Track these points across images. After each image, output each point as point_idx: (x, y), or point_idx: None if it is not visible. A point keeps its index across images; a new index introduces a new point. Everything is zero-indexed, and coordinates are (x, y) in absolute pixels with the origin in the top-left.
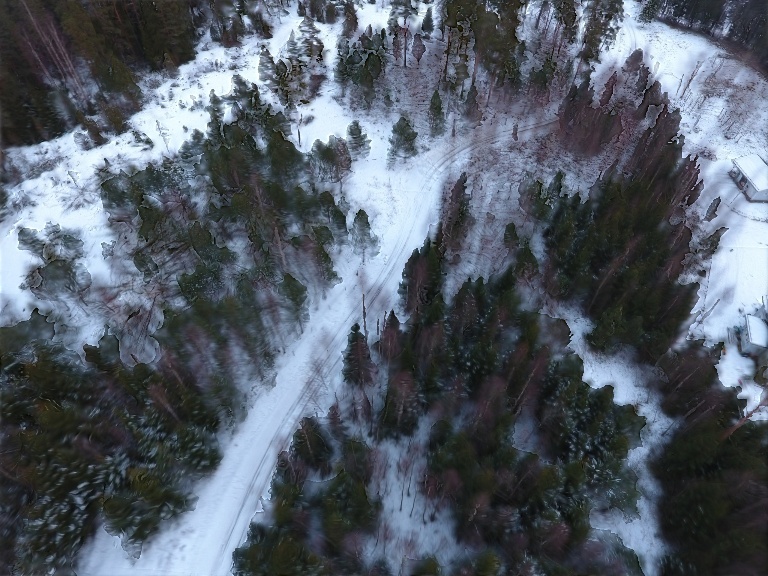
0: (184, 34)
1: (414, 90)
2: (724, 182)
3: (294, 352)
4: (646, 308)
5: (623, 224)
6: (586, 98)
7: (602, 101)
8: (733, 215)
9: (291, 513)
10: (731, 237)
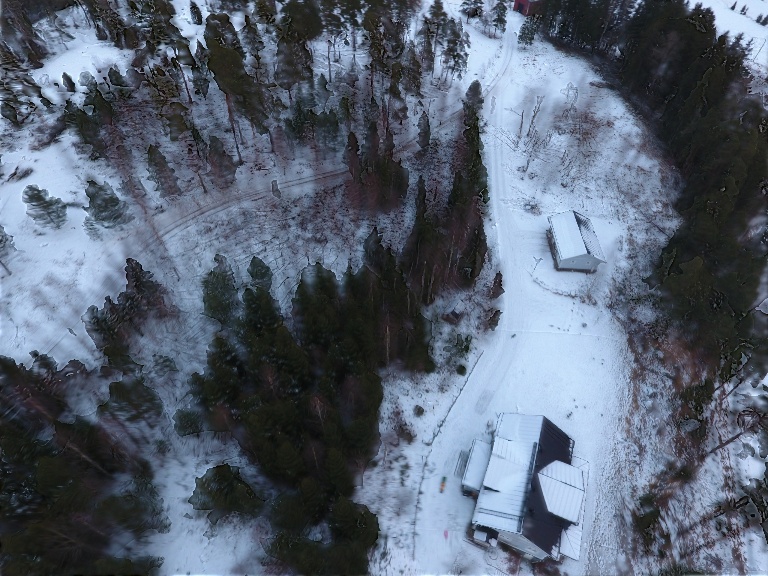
0: None
1: (185, 133)
2: (537, 243)
3: None
4: (278, 461)
5: (314, 328)
6: (374, 145)
7: (420, 143)
8: (534, 287)
9: None
10: (520, 317)
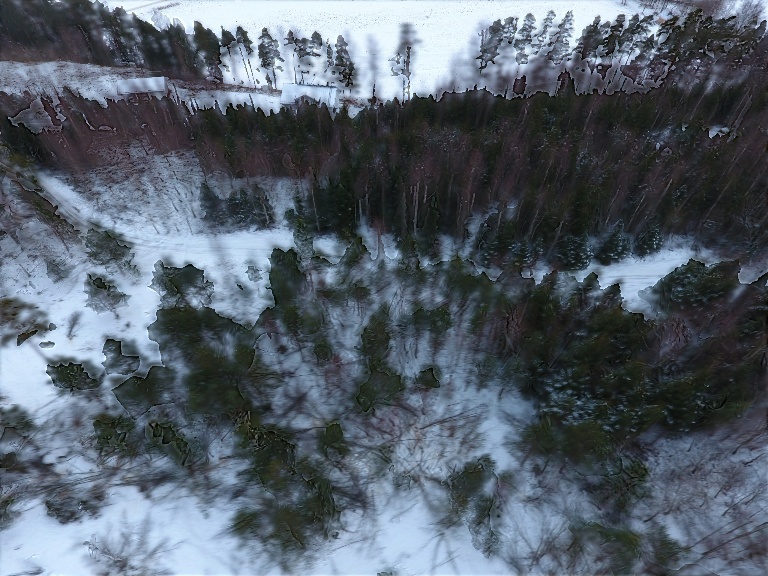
0: None
1: None
2: None
3: None
4: (331, 121)
5: (251, 120)
6: None
7: None
8: None
9: None
10: None
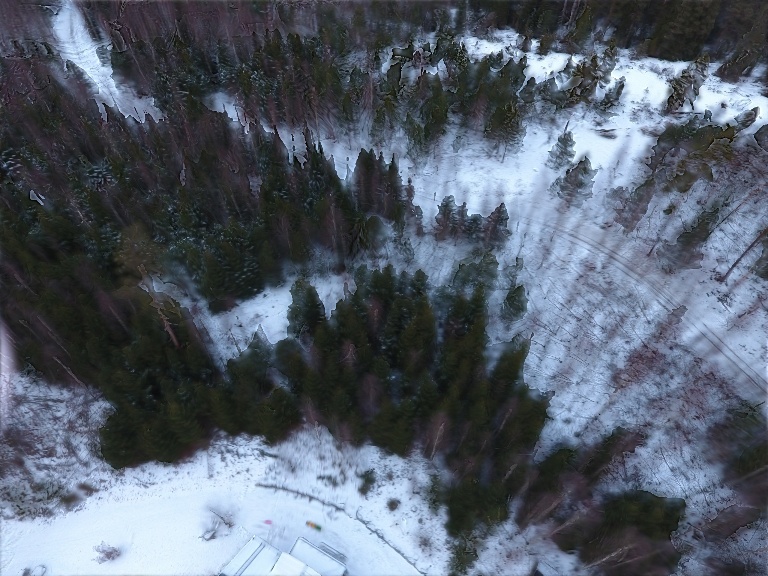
0: (692, 40)
1: (741, 219)
2: None
3: (334, 146)
4: None
5: (446, 353)
6: None
7: None
8: None
9: (214, 114)
10: None
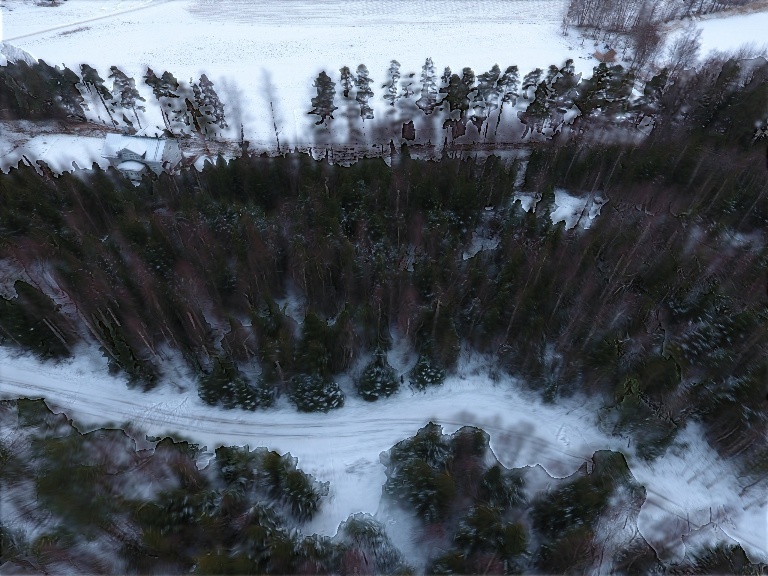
0: None
1: None
2: None
3: None
4: (111, 190)
5: None
6: None
7: None
8: None
9: None
10: None
